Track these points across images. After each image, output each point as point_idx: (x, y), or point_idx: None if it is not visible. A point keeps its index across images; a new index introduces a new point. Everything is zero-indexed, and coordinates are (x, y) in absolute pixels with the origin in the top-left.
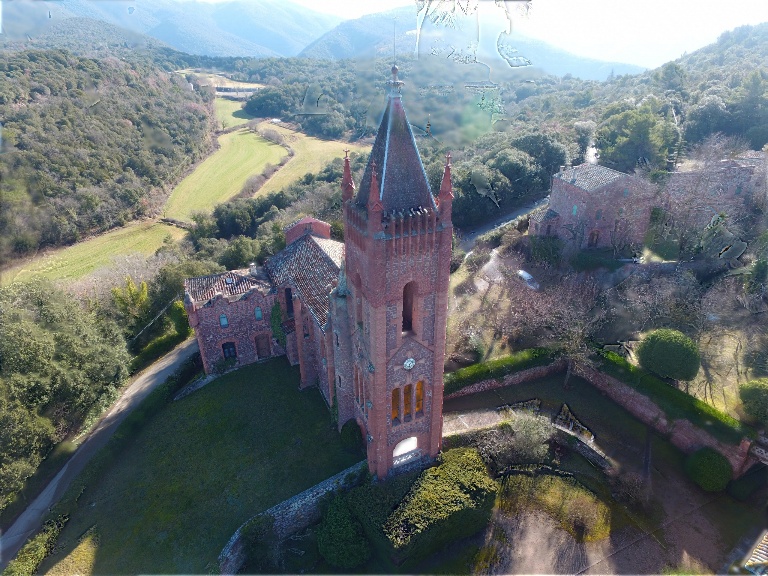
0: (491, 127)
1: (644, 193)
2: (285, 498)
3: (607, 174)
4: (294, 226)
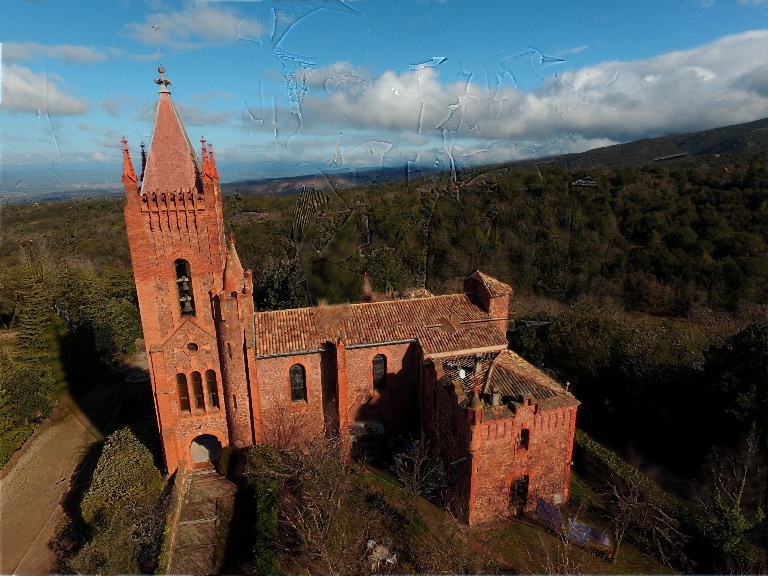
0: None
1: None
2: None
3: None
4: (469, 277)
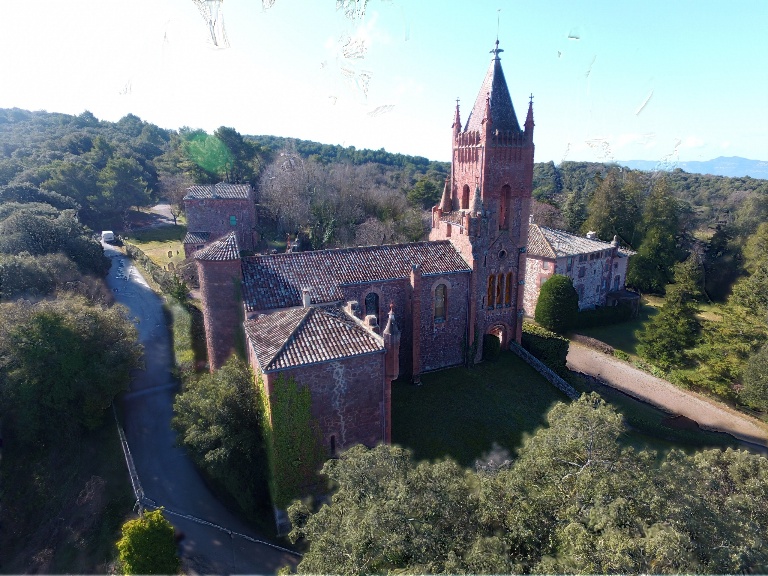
0: None
1: (299, 186)
2: (550, 393)
3: (233, 187)
4: None
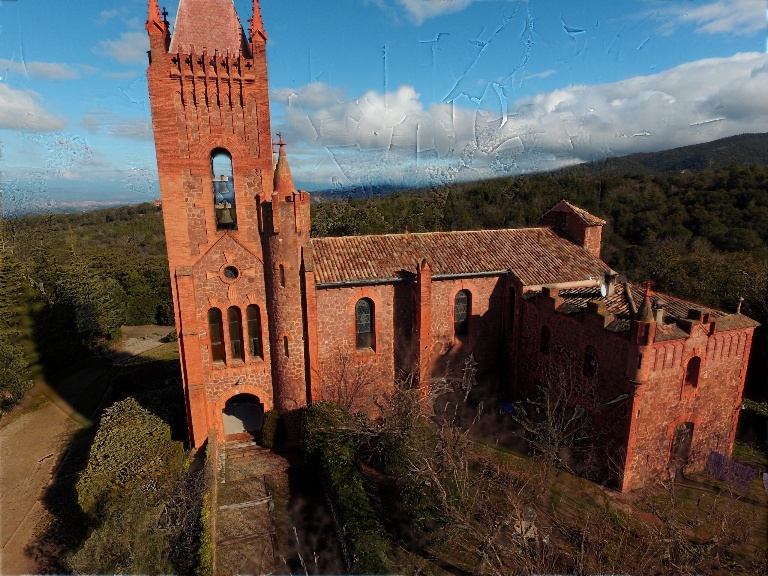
0: None
1: None
2: None
3: None
4: (548, 212)
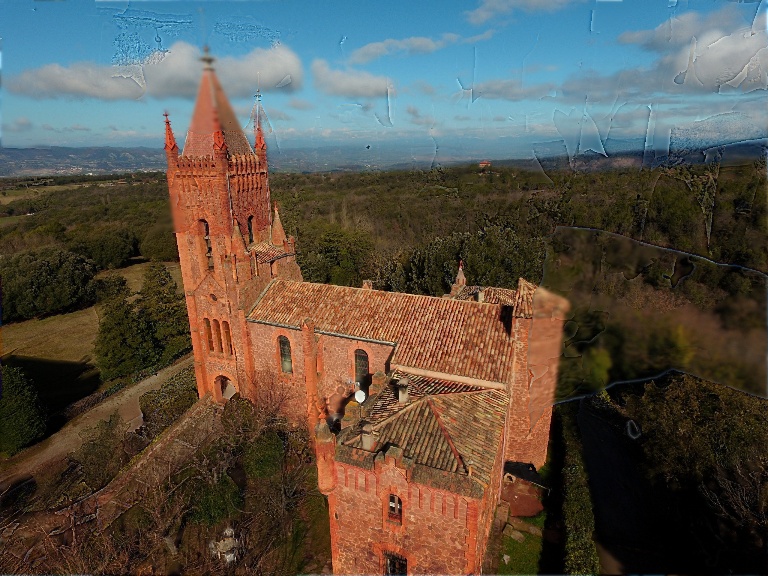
0: (145, 92)
1: None
2: None
3: None
4: None
